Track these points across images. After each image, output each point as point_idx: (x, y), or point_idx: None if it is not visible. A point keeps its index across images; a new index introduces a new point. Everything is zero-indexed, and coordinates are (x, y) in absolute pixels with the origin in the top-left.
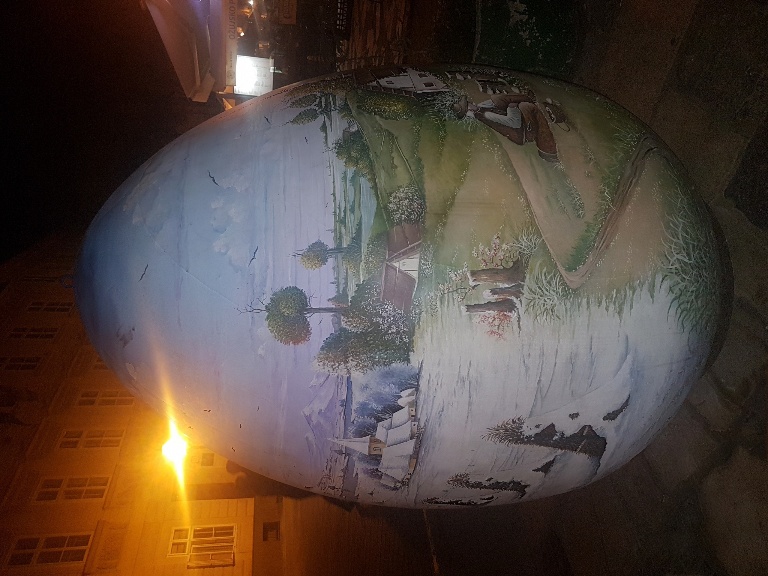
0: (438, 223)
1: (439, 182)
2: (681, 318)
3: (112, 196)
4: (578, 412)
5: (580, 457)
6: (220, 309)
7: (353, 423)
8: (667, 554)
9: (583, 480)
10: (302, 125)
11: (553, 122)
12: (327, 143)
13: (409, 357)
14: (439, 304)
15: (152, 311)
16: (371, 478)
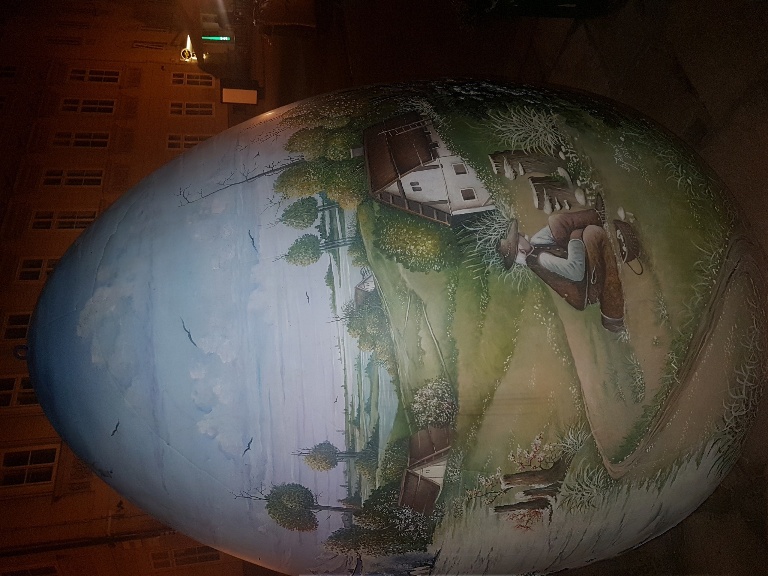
0: (471, 426)
1: (476, 374)
2: (721, 468)
3: (58, 277)
4: (594, 558)
5: None
6: (211, 488)
7: None
8: (641, 548)
9: None
10: (301, 267)
11: (624, 261)
12: (335, 308)
13: (426, 547)
14: (464, 507)
15: (131, 467)
16: None
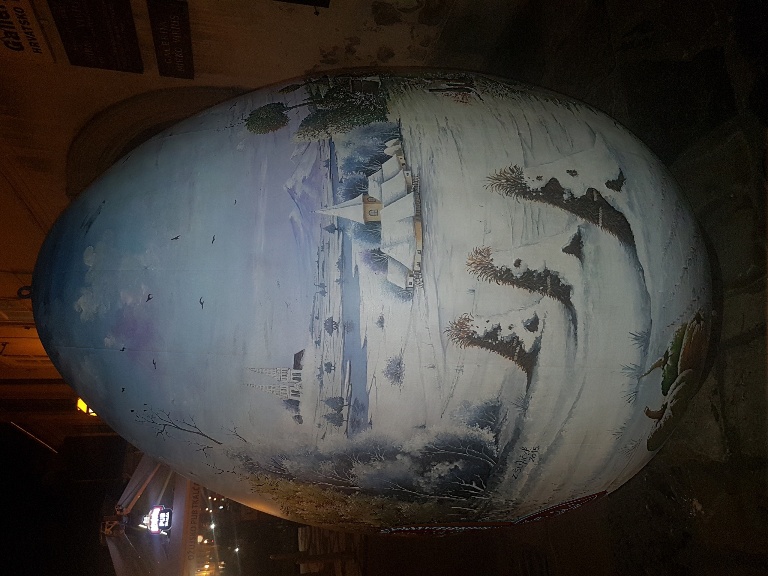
0: None
1: None
2: (632, 135)
3: None
4: (575, 170)
5: (610, 241)
6: (200, 138)
7: (341, 182)
8: None
9: (639, 308)
10: None
11: None
12: None
13: (386, 117)
14: (403, 89)
15: (129, 175)
16: (375, 273)
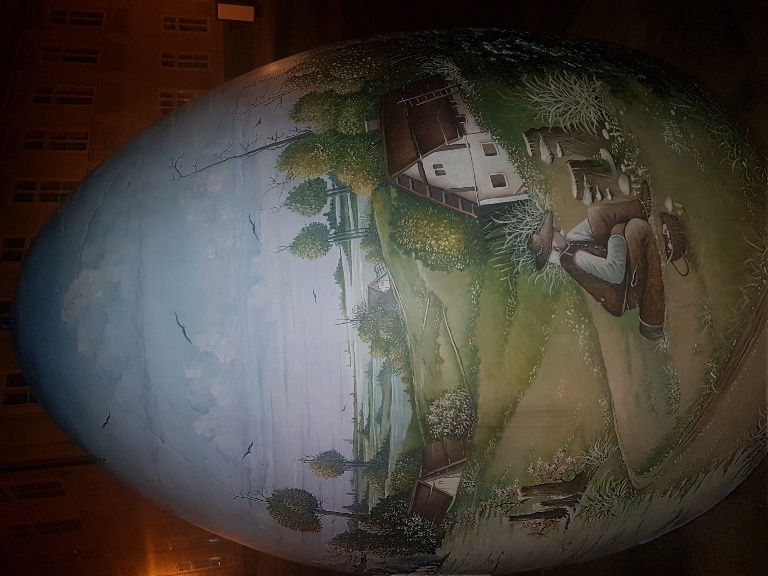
0: (490, 438)
1: (499, 384)
2: (747, 471)
3: (40, 249)
4: (606, 554)
5: None
6: (209, 487)
7: (365, 572)
8: None
9: None
10: (307, 261)
11: (668, 260)
12: (345, 309)
13: (435, 551)
14: (478, 517)
15: (124, 458)
16: None
